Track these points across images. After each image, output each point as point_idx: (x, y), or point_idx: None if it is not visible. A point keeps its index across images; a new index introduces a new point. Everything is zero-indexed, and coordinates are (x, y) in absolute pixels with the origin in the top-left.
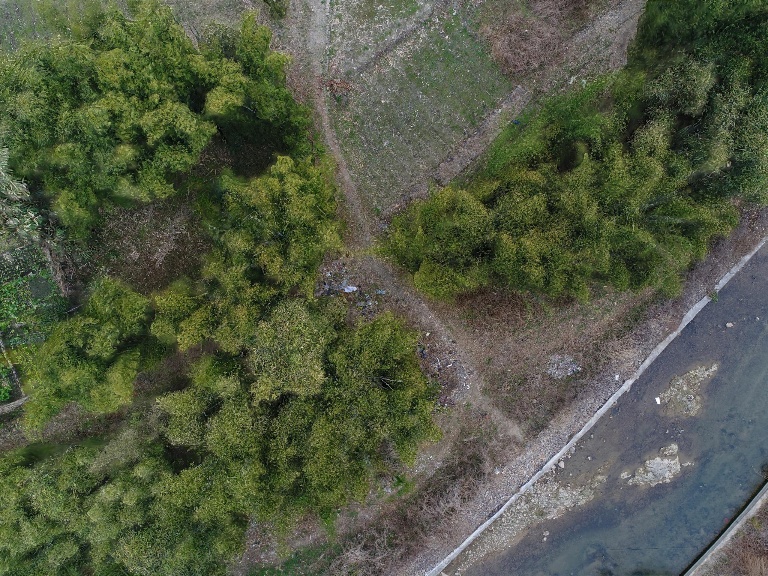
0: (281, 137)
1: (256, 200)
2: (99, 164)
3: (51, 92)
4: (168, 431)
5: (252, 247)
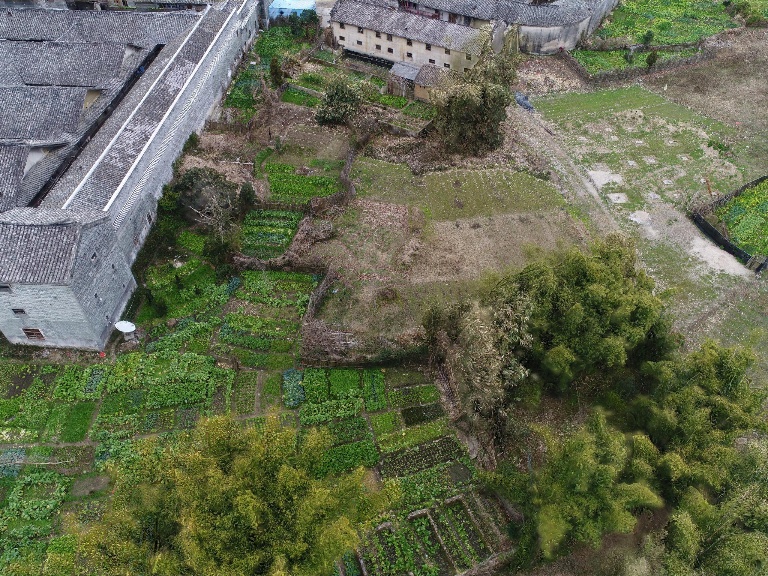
0: (655, 360)
1: (709, 357)
2: (587, 327)
3: (559, 279)
4: (671, 572)
5: (709, 396)
